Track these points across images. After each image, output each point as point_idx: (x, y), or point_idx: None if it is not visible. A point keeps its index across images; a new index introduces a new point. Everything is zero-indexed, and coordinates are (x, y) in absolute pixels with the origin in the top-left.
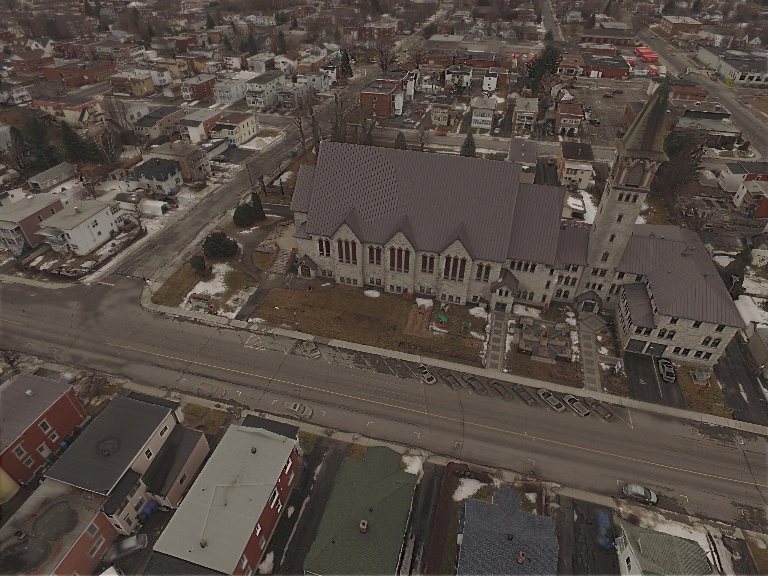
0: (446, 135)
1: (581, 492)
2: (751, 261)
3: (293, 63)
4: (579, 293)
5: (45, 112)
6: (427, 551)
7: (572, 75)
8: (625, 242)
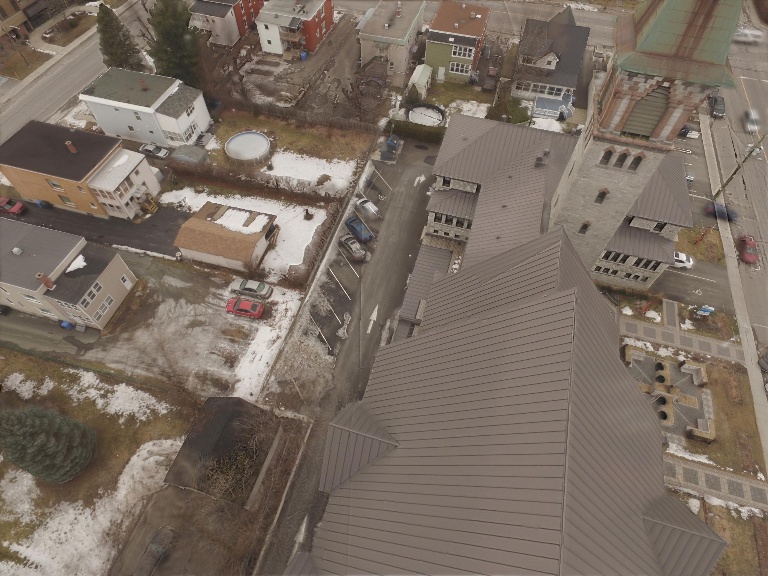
0: None
1: None
2: (421, 97)
3: None
4: None
5: None
6: None
7: None
8: None
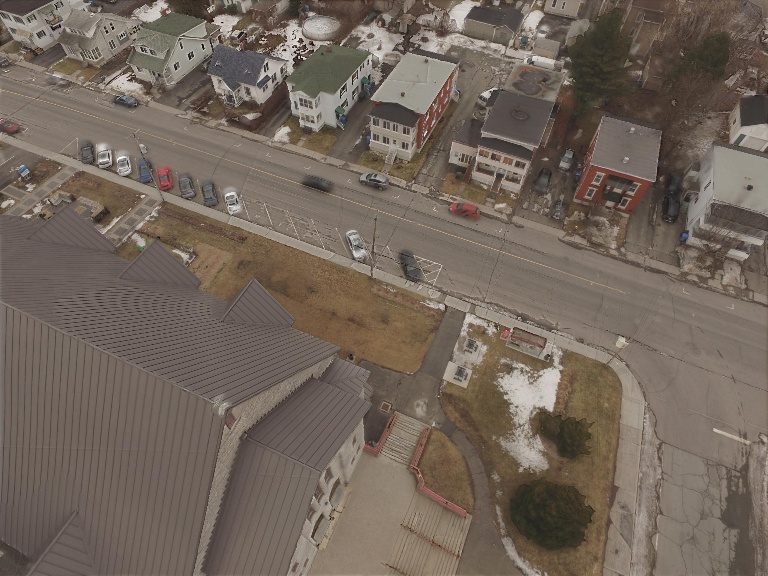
0: None
1: (167, 110)
2: None
3: None
4: None
5: None
6: None
7: None
8: None
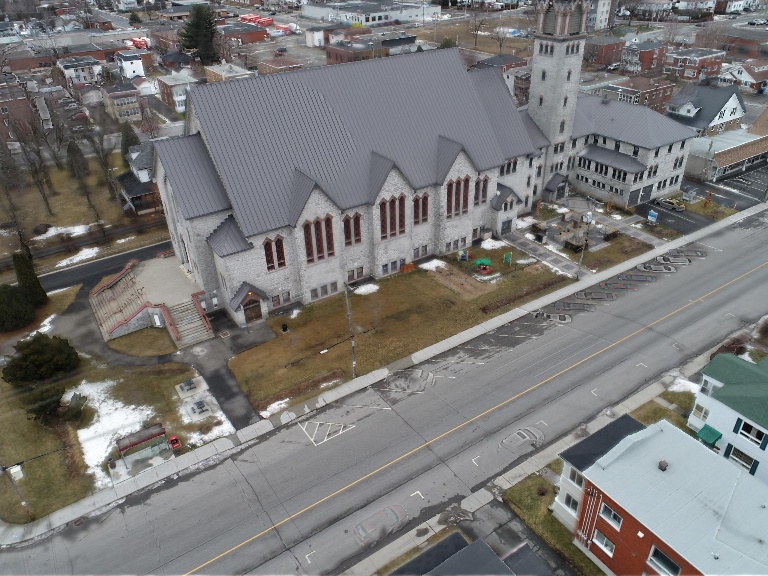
0: (158, 128)
1: None
2: None
3: None
4: (546, 182)
5: None
6: None
7: None
8: (575, 102)
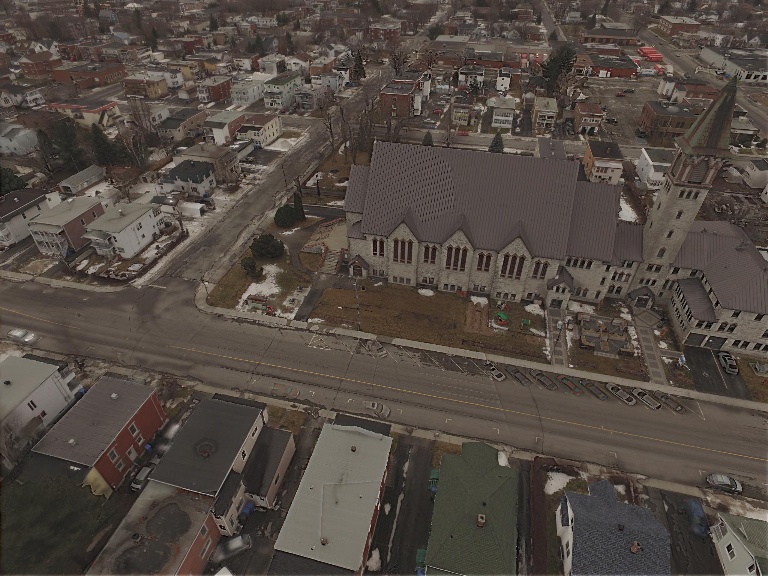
0: (468, 135)
1: (667, 483)
2: None
3: (305, 64)
4: (632, 289)
5: (65, 115)
6: (529, 544)
7: (581, 75)
8: (683, 238)
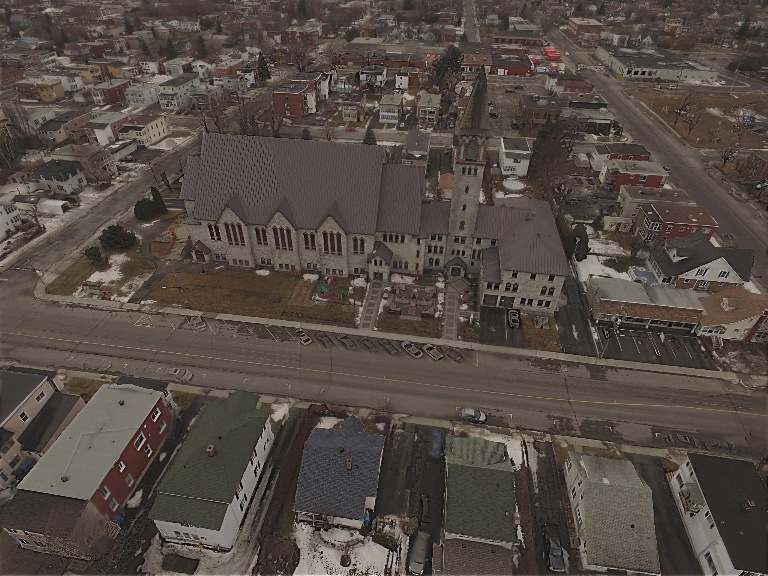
0: (355, 130)
1: (424, 419)
2: (603, 227)
3: (211, 66)
4: (447, 260)
5: None
6: None
7: None
8: (475, 211)
